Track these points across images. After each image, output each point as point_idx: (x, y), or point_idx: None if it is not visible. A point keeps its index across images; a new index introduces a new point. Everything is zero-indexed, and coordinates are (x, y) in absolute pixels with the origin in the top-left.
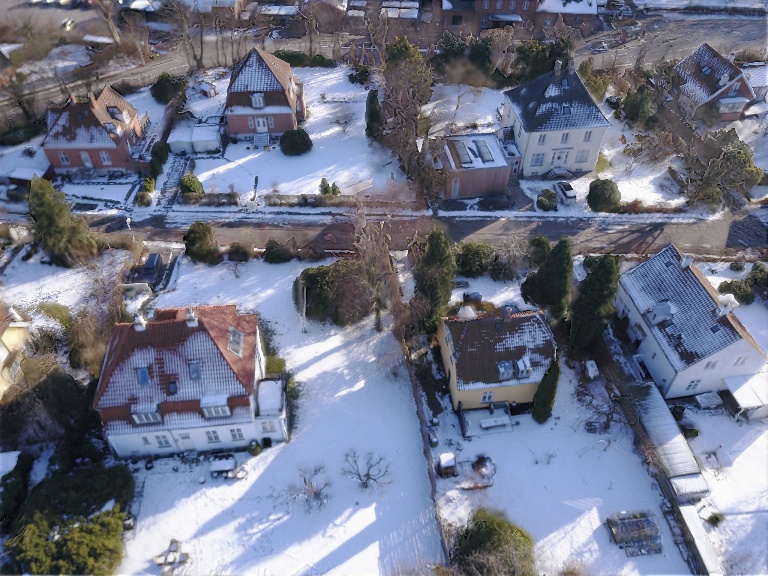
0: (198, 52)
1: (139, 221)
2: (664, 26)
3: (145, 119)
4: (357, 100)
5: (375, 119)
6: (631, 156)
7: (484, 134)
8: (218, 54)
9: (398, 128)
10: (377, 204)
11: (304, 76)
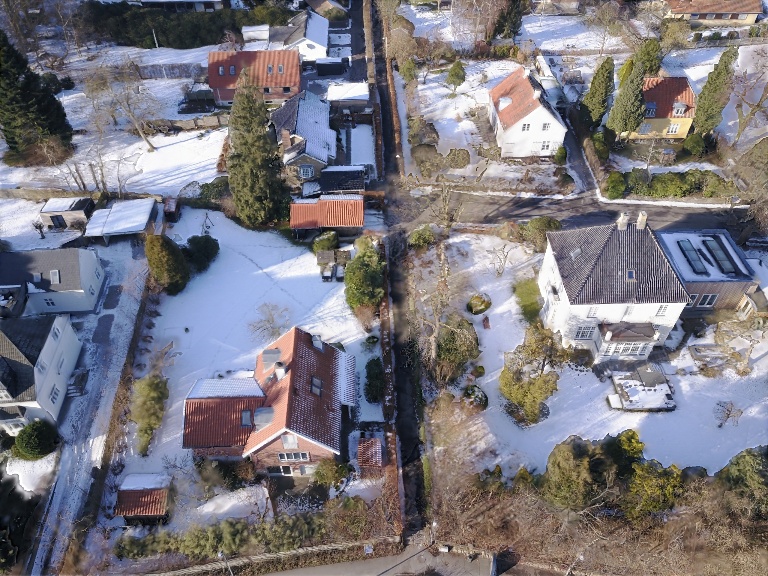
0: None
1: None
2: None
3: None
4: None
5: None
6: None
7: (698, 282)
8: None
9: None
10: None
11: None
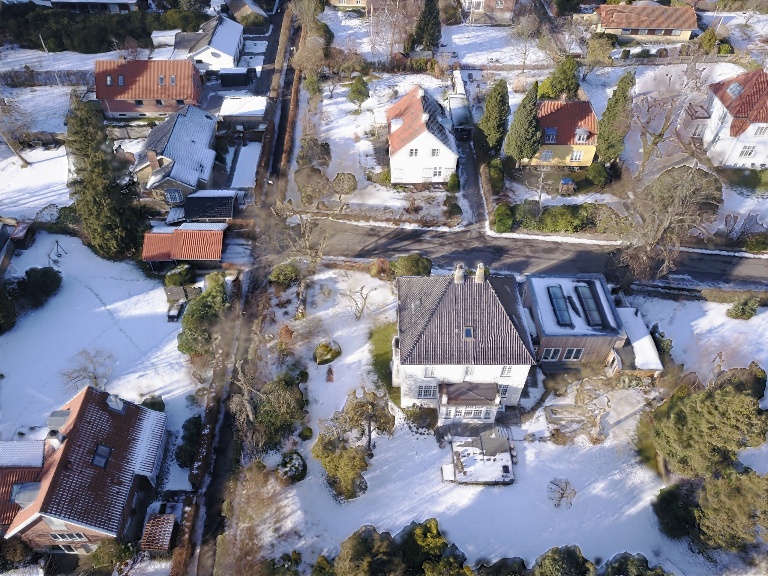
0: None
1: None
2: None
3: None
4: None
5: None
6: None
7: (559, 335)
8: None
9: None
10: (676, 298)
11: None
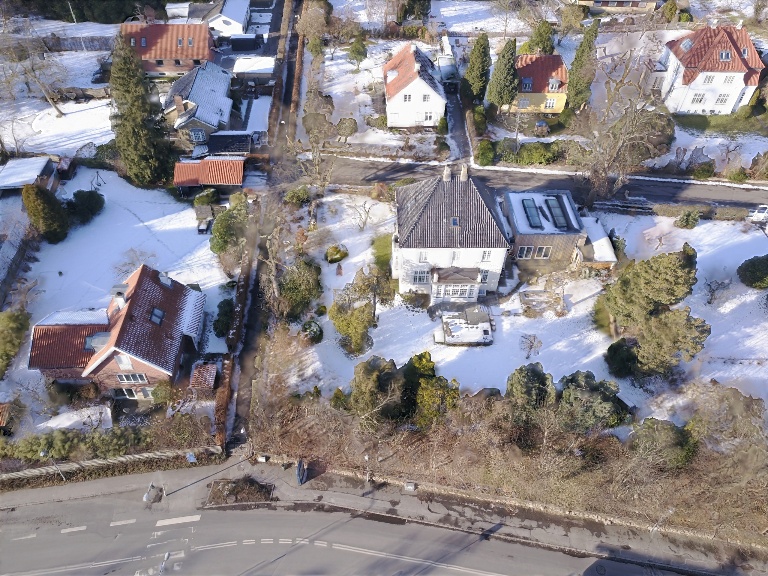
0: None
1: None
2: None
3: None
4: (719, 359)
5: None
6: None
7: (530, 234)
8: None
9: None
10: (632, 213)
11: None
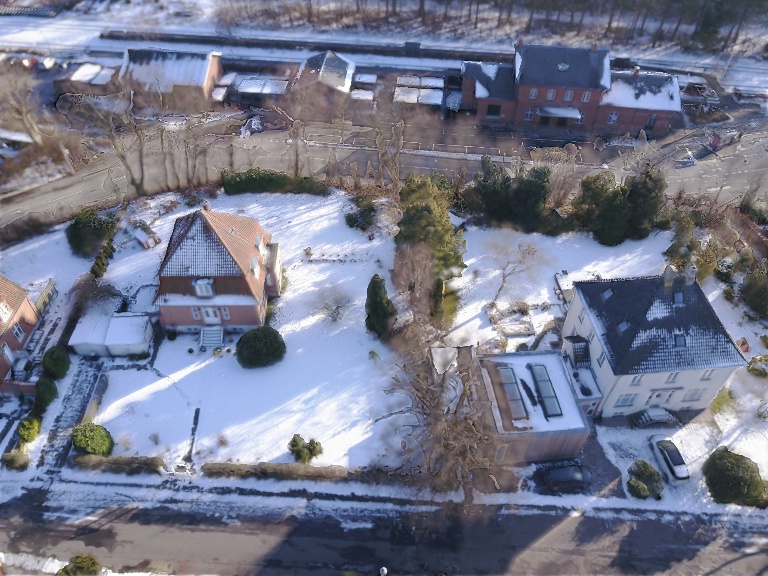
0: (137, 175)
1: (3, 503)
2: (764, 123)
3: (46, 292)
4: (356, 258)
5: (380, 315)
6: (766, 391)
7: (544, 352)
8: (167, 175)
9: (416, 411)
10: (378, 476)
11: (284, 211)
